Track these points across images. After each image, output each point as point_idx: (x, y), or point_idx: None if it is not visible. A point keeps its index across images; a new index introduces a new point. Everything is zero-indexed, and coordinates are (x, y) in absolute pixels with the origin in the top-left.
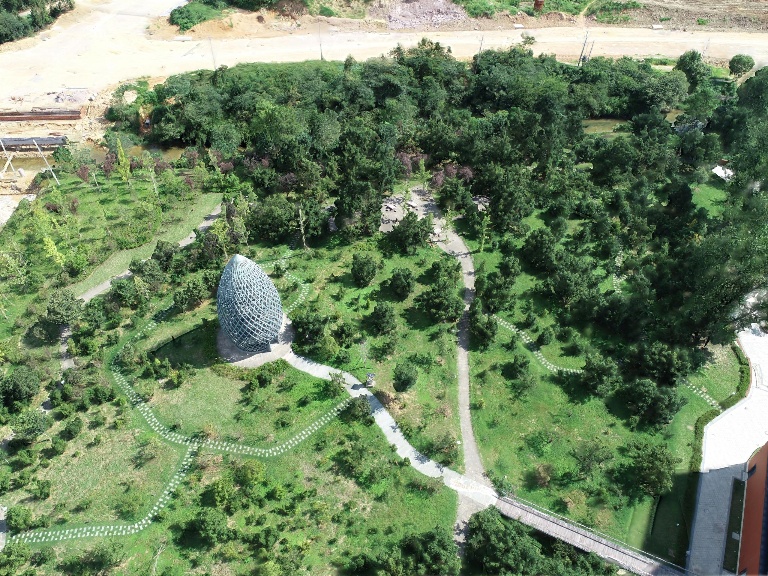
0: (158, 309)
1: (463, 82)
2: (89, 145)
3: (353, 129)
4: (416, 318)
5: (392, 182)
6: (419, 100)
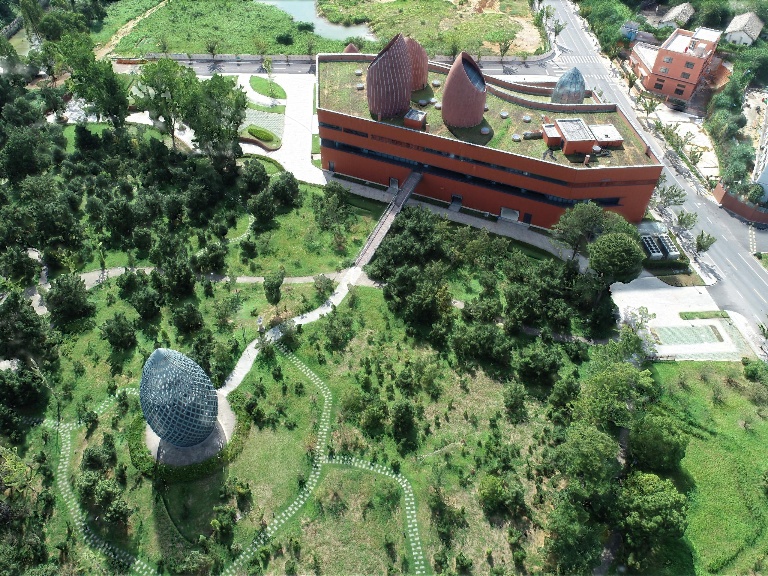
0: (109, 567)
1: None
2: None
3: None
4: None
5: None
6: None
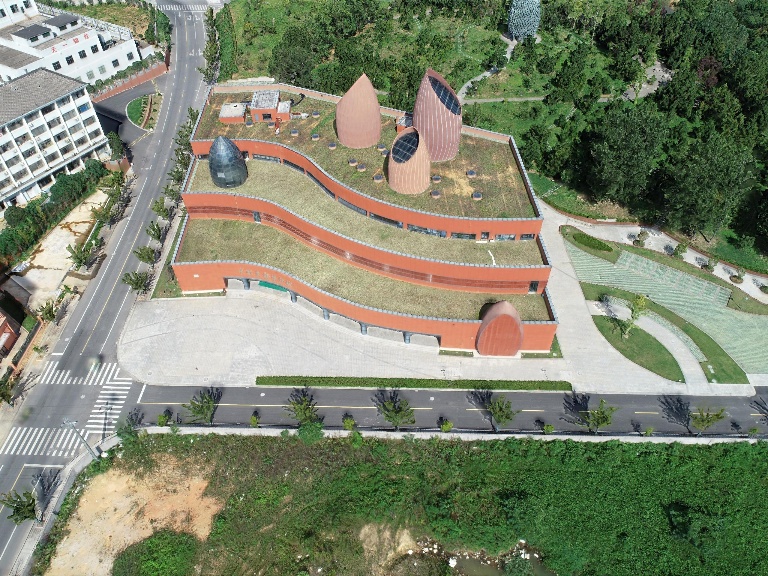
0: None
1: None
2: (671, 1)
3: (716, 30)
4: None
5: None
6: None
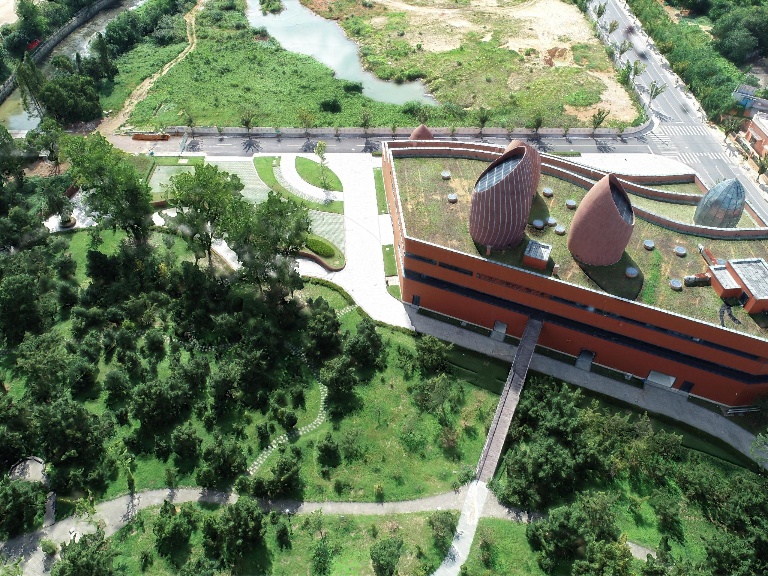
0: None
1: None
2: None
3: None
4: (252, 566)
5: None
6: None
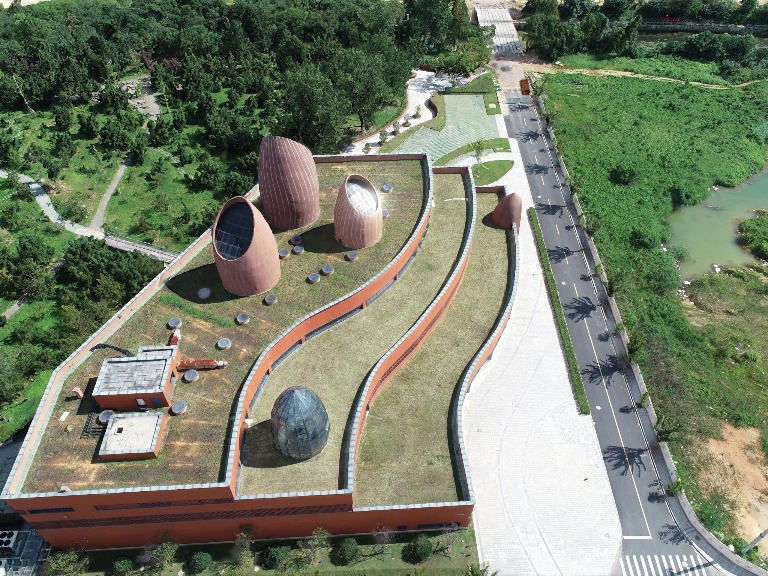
0: None
1: (219, 11)
2: None
3: (93, 35)
4: (97, 149)
5: (118, 71)
6: (179, 24)
